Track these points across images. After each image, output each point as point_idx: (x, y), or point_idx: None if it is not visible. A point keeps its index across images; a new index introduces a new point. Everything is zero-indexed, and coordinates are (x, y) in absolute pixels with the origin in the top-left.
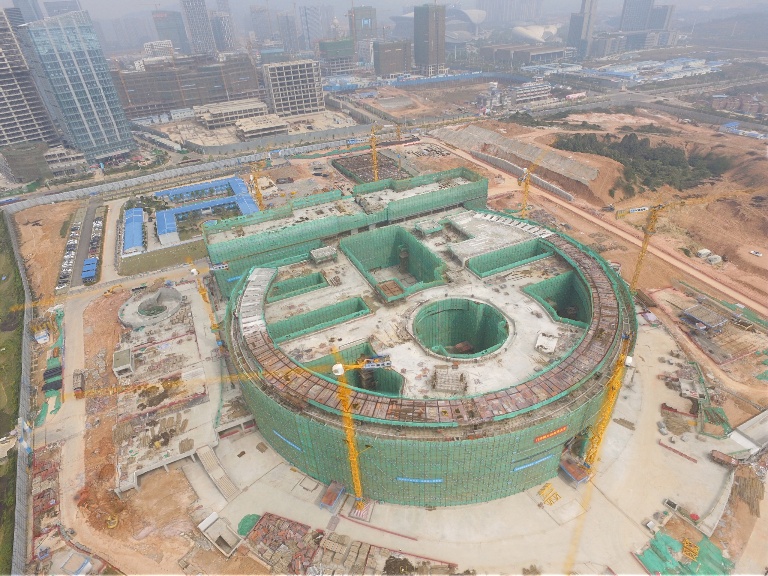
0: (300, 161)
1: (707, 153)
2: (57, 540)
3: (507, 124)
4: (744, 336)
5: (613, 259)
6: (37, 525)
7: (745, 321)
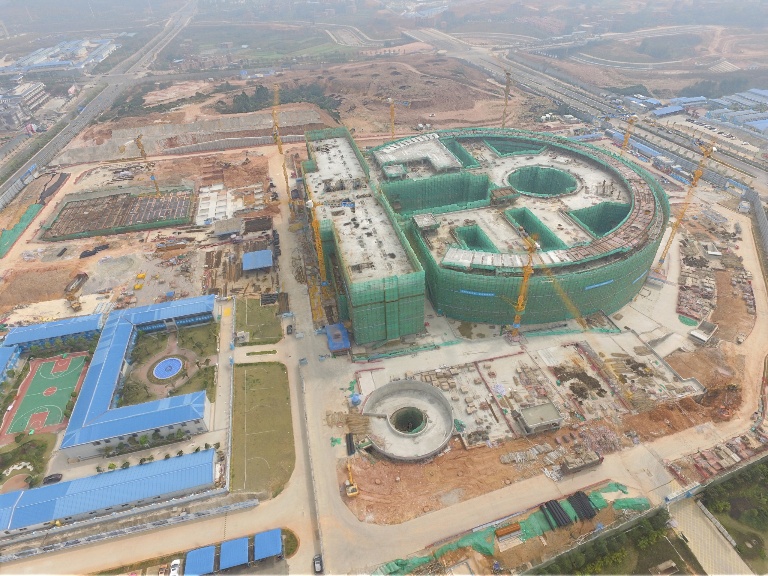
0: None
1: (297, 87)
2: (765, 427)
3: (149, 116)
4: None
5: None
6: (763, 448)
7: None
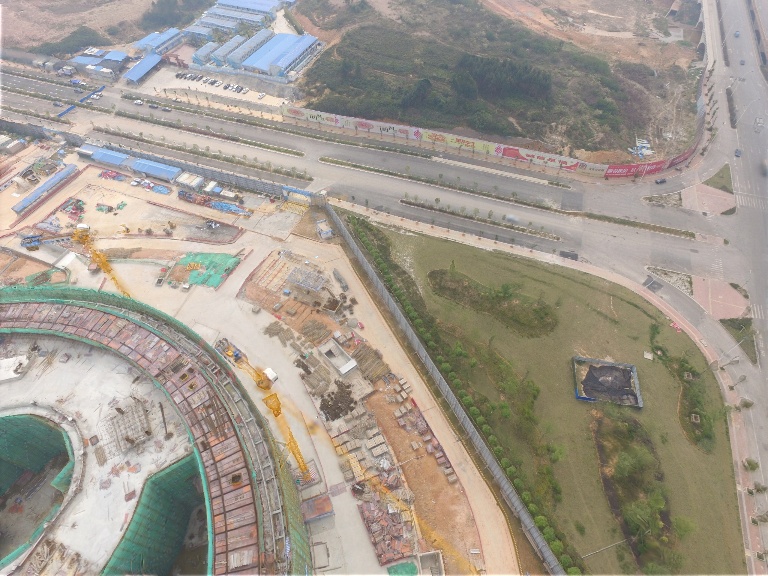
0: None
1: None
2: None
3: None
4: None
5: None
6: None
7: None
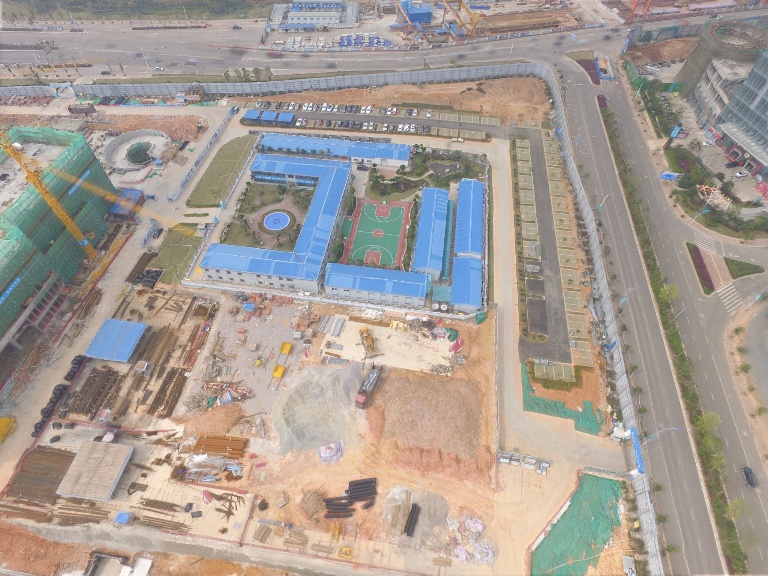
0: (528, 504)
1: None
2: None
3: None
4: None
5: None
6: None
7: None
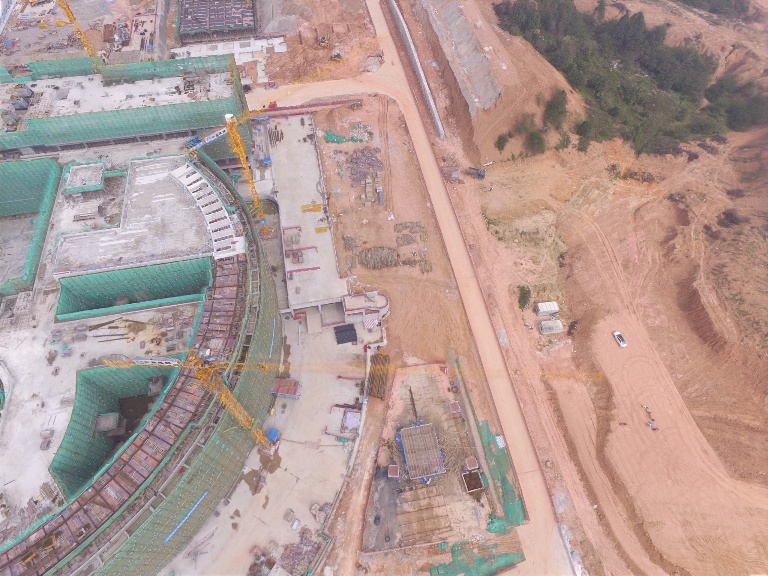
0: None
1: (750, 80)
2: None
3: None
4: (454, 504)
5: (393, 285)
6: None
7: (479, 476)
